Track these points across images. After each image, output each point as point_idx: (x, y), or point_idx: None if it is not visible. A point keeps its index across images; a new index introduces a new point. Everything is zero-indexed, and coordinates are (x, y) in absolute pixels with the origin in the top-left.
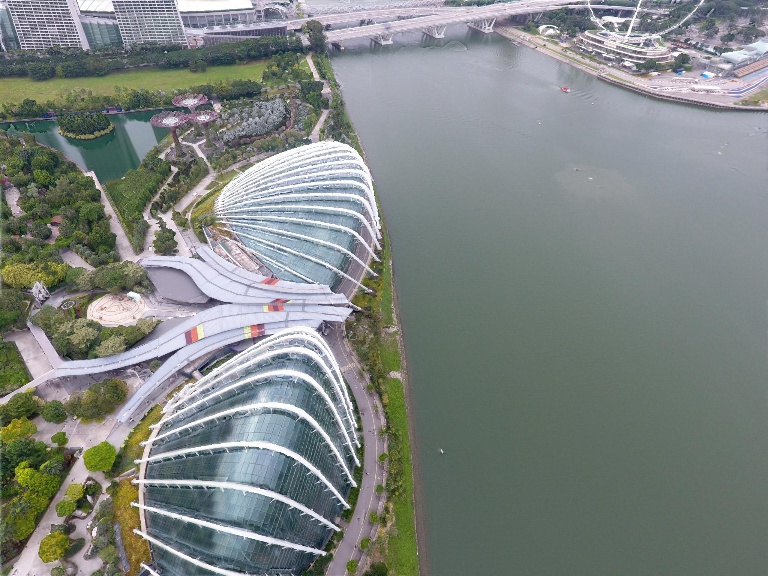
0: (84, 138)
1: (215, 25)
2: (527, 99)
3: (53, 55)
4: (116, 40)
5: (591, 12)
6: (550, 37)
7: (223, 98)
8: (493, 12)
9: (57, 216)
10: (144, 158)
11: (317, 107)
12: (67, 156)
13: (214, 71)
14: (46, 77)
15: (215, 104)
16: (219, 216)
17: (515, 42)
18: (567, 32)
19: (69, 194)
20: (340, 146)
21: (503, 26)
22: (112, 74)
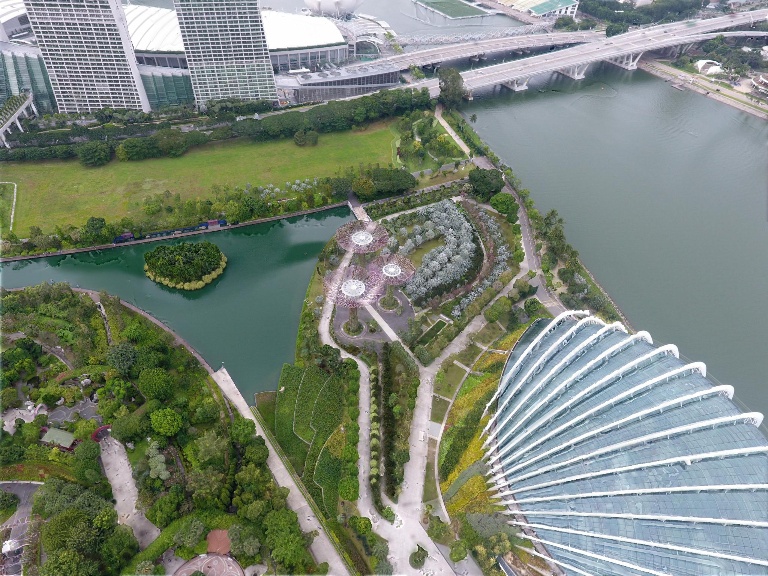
0: (189, 288)
1: (299, 65)
2: (765, 186)
3: (103, 120)
4: (184, 96)
5: (743, 40)
6: (716, 77)
7: (365, 198)
8: (638, 44)
9: (215, 533)
10: (303, 341)
11: (515, 219)
12: (173, 332)
13: (327, 143)
14: (103, 162)
15: (355, 208)
16: (524, 536)
17: (676, 85)
18: (735, 70)
19: (217, 458)
20: (665, 350)
21: (646, 60)
22: (191, 152)
